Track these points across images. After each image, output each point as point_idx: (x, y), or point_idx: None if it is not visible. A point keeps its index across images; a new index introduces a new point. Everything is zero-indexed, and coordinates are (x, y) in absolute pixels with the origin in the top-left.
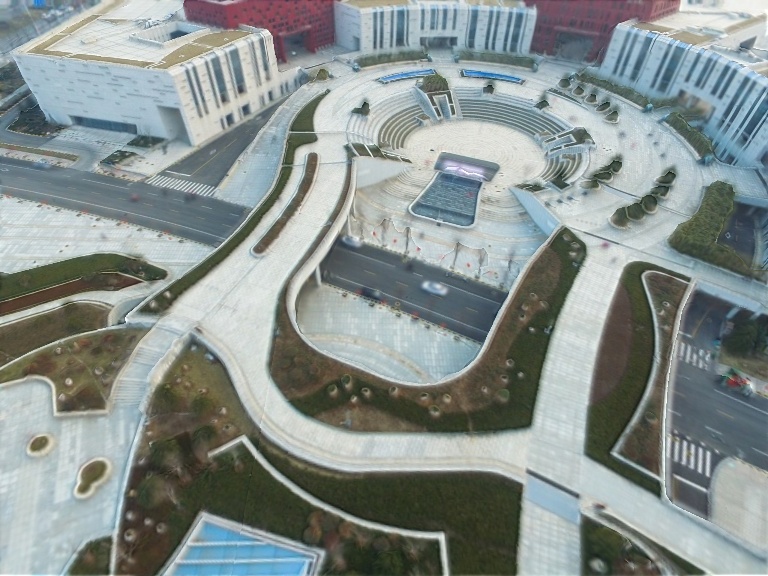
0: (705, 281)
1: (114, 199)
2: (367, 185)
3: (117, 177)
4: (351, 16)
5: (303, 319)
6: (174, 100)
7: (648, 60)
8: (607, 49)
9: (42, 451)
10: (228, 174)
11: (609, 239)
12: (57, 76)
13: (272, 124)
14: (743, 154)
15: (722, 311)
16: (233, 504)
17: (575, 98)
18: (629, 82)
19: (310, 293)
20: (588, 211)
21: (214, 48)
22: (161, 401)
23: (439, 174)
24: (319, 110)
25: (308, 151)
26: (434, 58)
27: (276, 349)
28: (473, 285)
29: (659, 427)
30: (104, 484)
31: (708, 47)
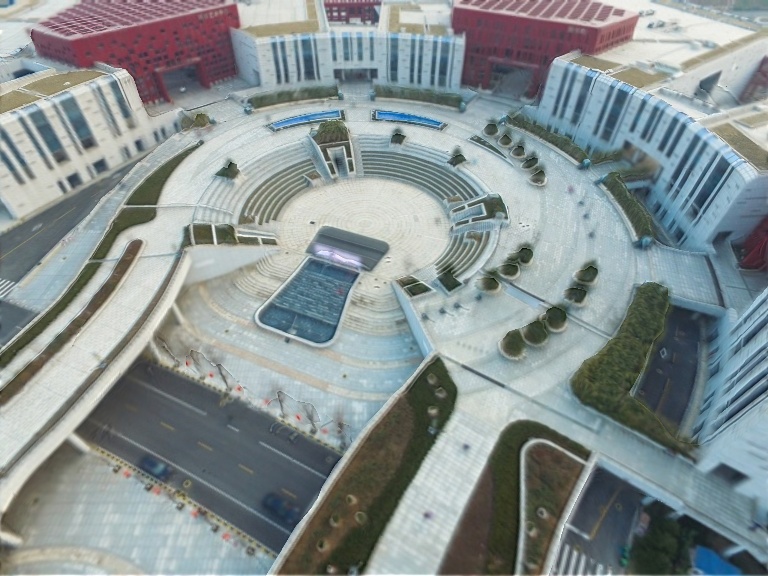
0: (609, 459)
1: None
2: (215, 276)
3: None
4: (248, 46)
5: (39, 518)
6: None
7: (589, 102)
8: (544, 87)
9: None
10: (41, 262)
11: (493, 378)
12: None
13: (122, 187)
14: (693, 231)
15: (636, 495)
16: None
17: (500, 149)
18: (570, 126)
19: (66, 469)
20: (476, 327)
21: (42, 97)
22: None
23: (308, 261)
24: (178, 171)
25: (134, 236)
26: (347, 94)
27: None
28: (303, 446)
29: None
30: None
31: (656, 91)
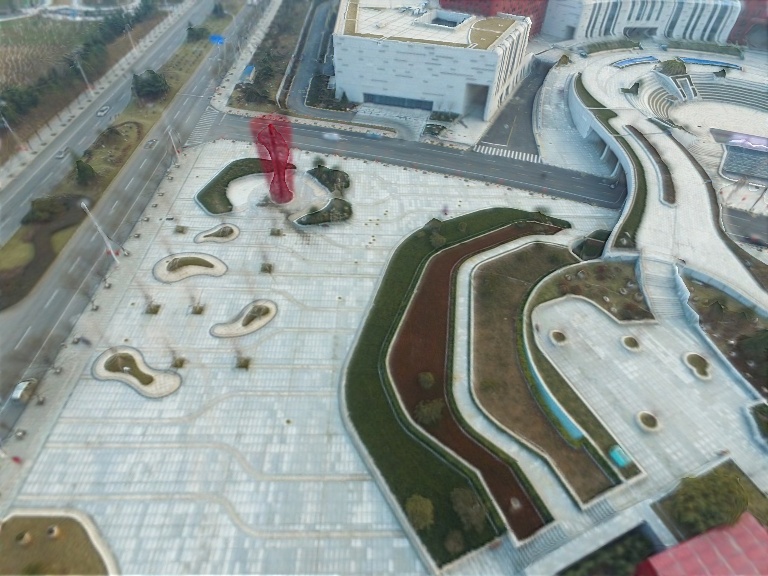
0: None
1: (462, 164)
2: None
3: (446, 146)
4: (569, 7)
5: None
6: (489, 78)
7: None
8: None
9: (638, 348)
10: (539, 145)
11: None
12: (373, 56)
13: (544, 103)
14: None
15: None
16: None
17: None
18: None
19: None
20: None
21: (502, 33)
22: (700, 313)
23: (727, 146)
24: (590, 90)
25: (620, 124)
26: (642, 46)
27: (758, 276)
28: None
29: None
30: (713, 370)
31: None
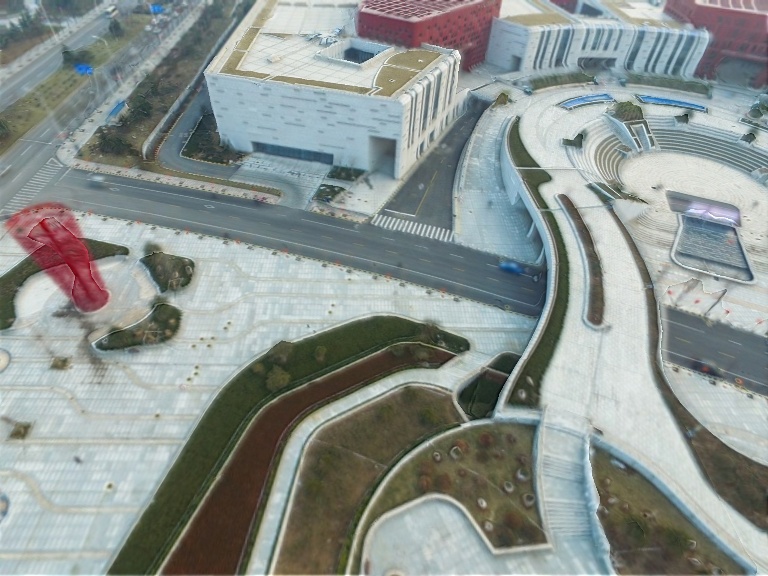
0: None
1: (350, 245)
2: None
3: (338, 217)
4: (514, 34)
5: None
6: (394, 131)
7: None
8: None
9: None
10: (455, 214)
11: None
12: (255, 100)
13: (472, 155)
14: None
15: None
16: None
17: None
18: None
19: None
20: None
21: (419, 71)
22: (614, 532)
23: (683, 217)
24: (525, 141)
25: (553, 192)
26: (597, 81)
27: (701, 456)
28: None
29: None
30: None
31: None
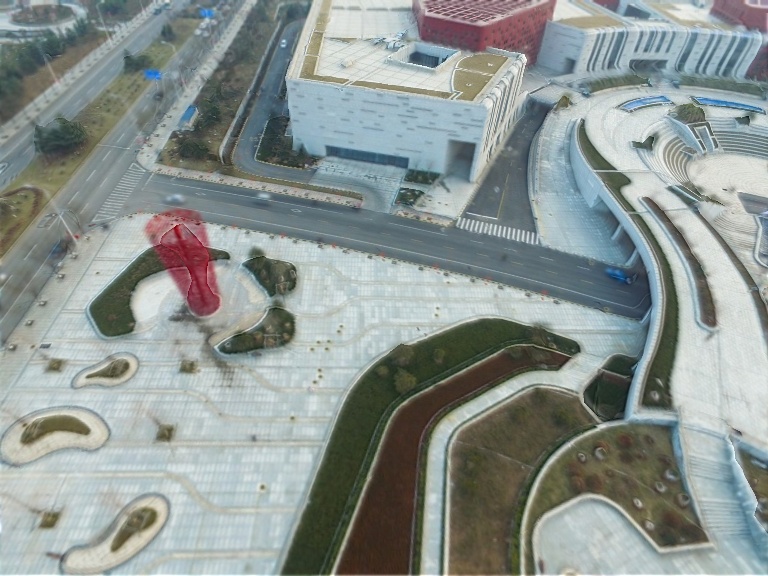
0: None
1: (441, 248)
2: None
3: (423, 220)
4: (569, 37)
5: None
6: (475, 135)
7: None
8: None
9: None
10: (536, 217)
11: None
12: (336, 105)
13: (542, 157)
14: None
15: None
16: None
17: None
18: None
19: None
20: None
21: (492, 75)
22: None
23: (761, 219)
24: (595, 143)
25: (635, 194)
26: (651, 82)
27: None
28: None
29: None
30: None
31: None
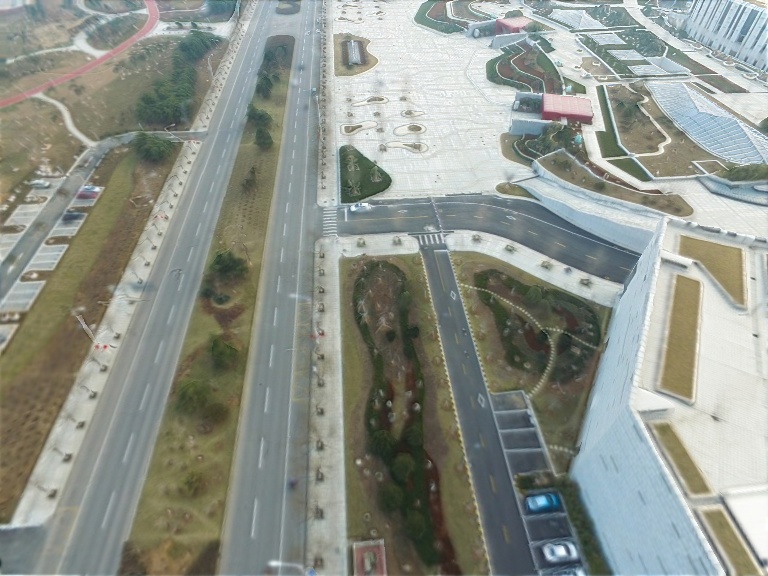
0: None
1: None
2: None
3: None
4: None
5: None
6: None
7: None
8: None
9: None
10: None
11: None
12: None
13: None
14: None
15: (673, 0)
16: (560, 8)
17: None
18: None
19: None
20: None
21: None
22: None
23: None
24: None
25: None
26: None
27: None
28: None
29: (656, 0)
30: None
31: None
